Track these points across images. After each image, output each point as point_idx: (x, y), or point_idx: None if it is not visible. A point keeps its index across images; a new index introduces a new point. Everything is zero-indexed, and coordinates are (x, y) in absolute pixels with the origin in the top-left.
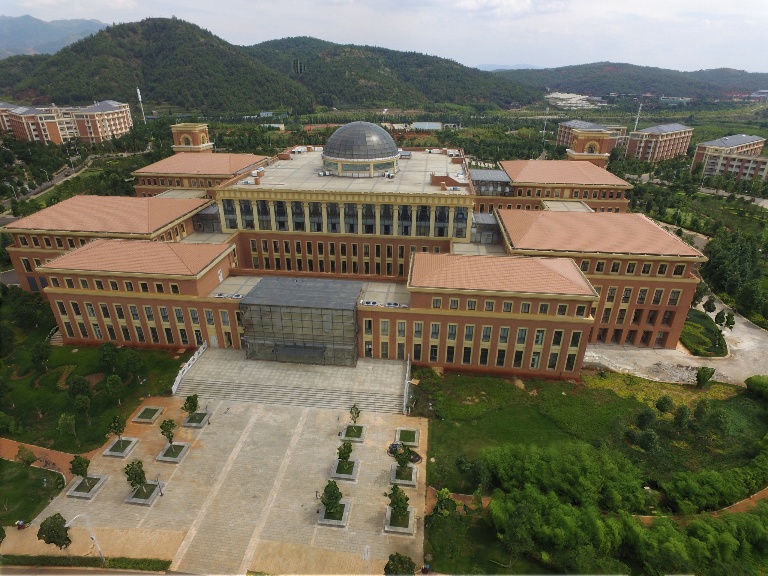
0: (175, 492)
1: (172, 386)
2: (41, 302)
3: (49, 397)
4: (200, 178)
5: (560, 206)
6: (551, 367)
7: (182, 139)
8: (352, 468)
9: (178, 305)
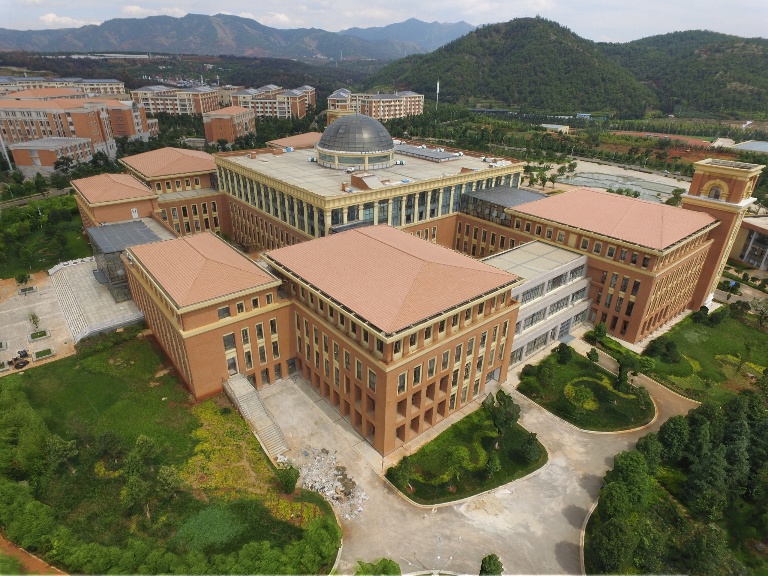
0: None
1: None
2: None
3: None
4: None
5: (538, 252)
6: None
7: None
8: None
9: None
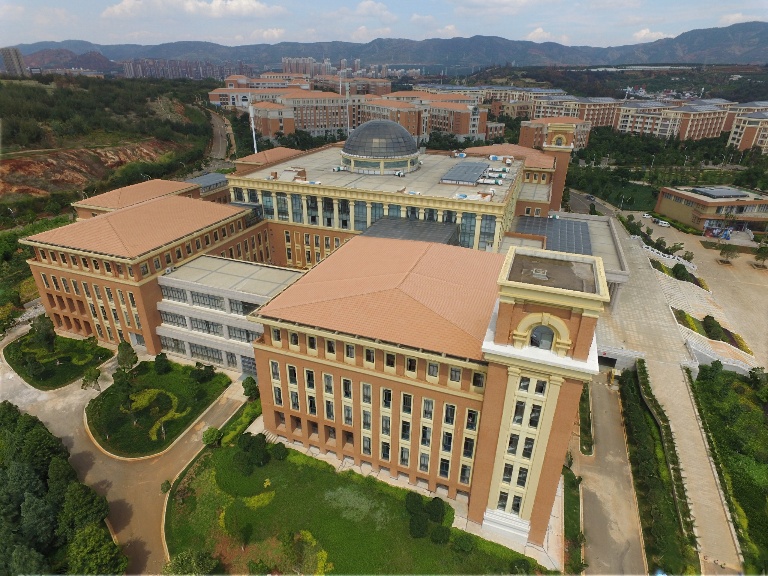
0: None
1: None
2: None
3: None
4: None
5: None
6: None
7: None
8: None
9: None
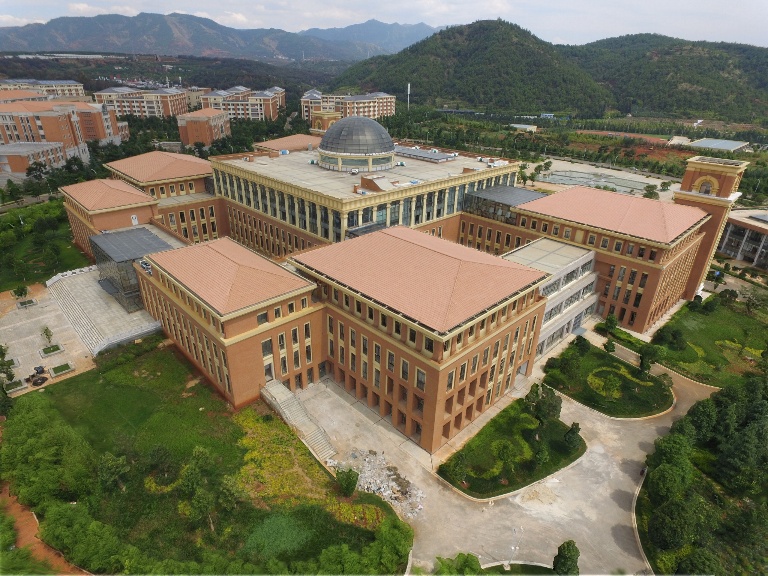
0: None
1: (49, 281)
2: None
3: None
4: None
5: (548, 248)
6: None
7: (316, 124)
8: None
9: (90, 231)
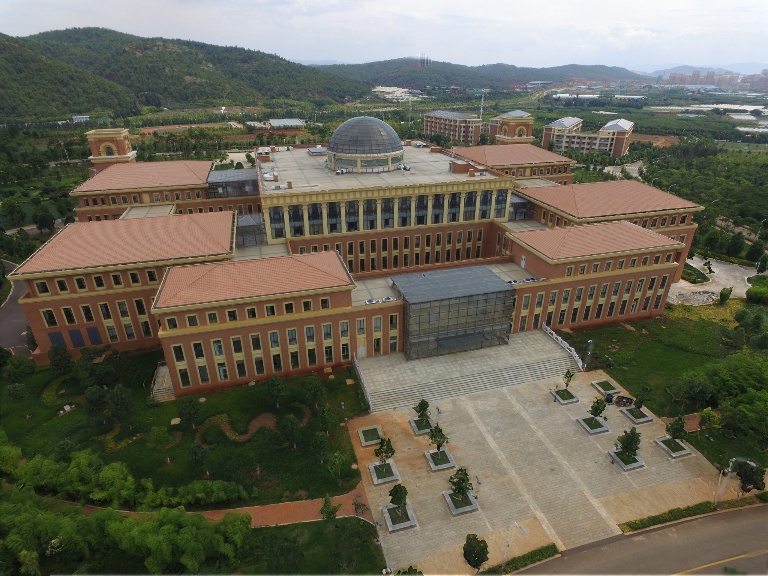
0: (484, 491)
1: None
2: (117, 356)
3: (239, 452)
4: (165, 191)
5: (530, 183)
6: (643, 309)
7: (102, 148)
8: (598, 422)
9: (329, 320)
